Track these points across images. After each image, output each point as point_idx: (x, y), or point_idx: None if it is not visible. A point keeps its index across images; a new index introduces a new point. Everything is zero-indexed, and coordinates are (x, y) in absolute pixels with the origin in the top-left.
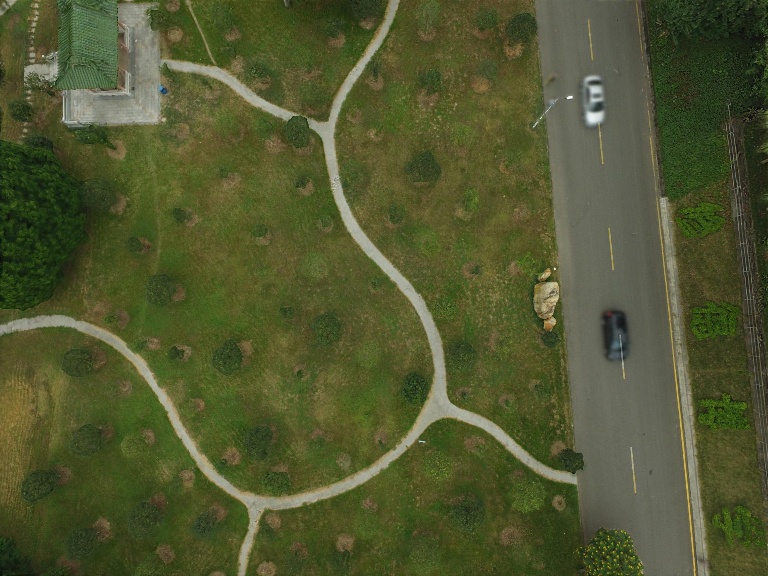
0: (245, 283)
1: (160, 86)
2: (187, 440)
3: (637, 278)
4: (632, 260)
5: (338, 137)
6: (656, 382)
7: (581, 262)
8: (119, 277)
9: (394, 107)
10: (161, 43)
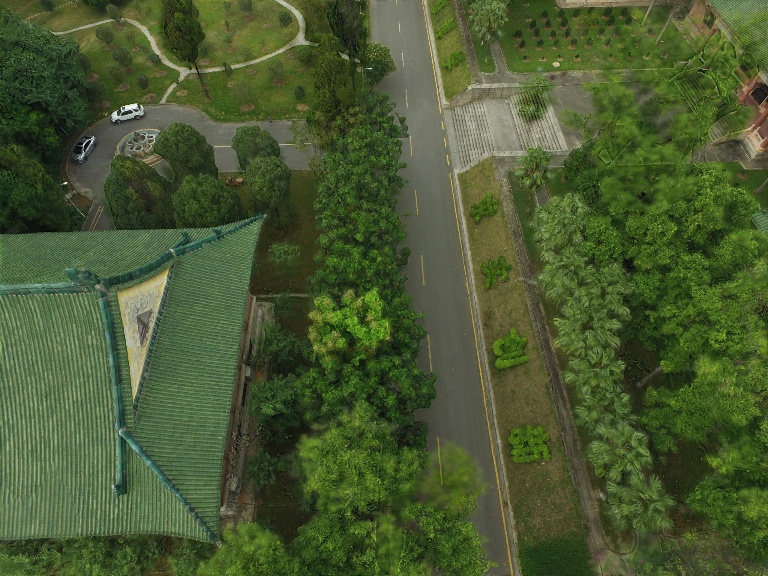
0: (210, 7)
1: None
2: (157, 51)
3: (409, 7)
4: (407, 3)
5: None
6: (417, 34)
7: (381, 3)
8: (147, 5)
9: None
10: None
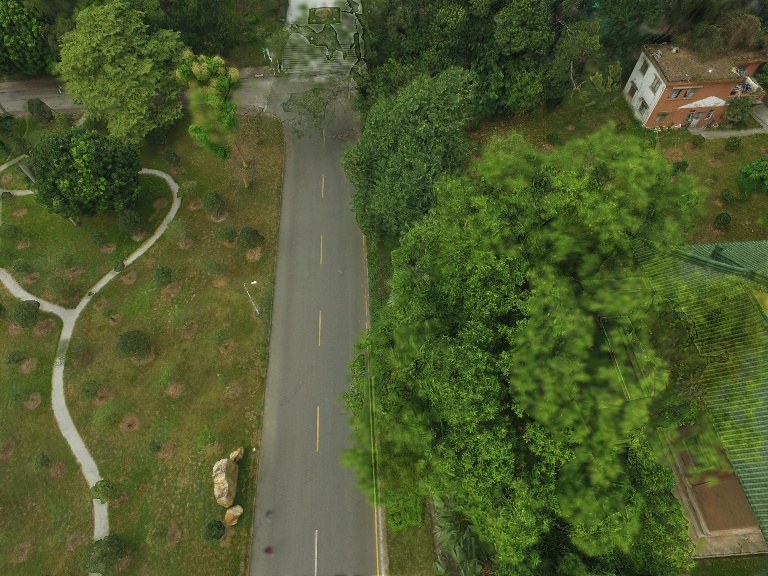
0: None
1: None
2: None
3: (342, 461)
4: (339, 440)
5: (78, 321)
6: None
7: (285, 442)
8: None
9: (139, 298)
10: None
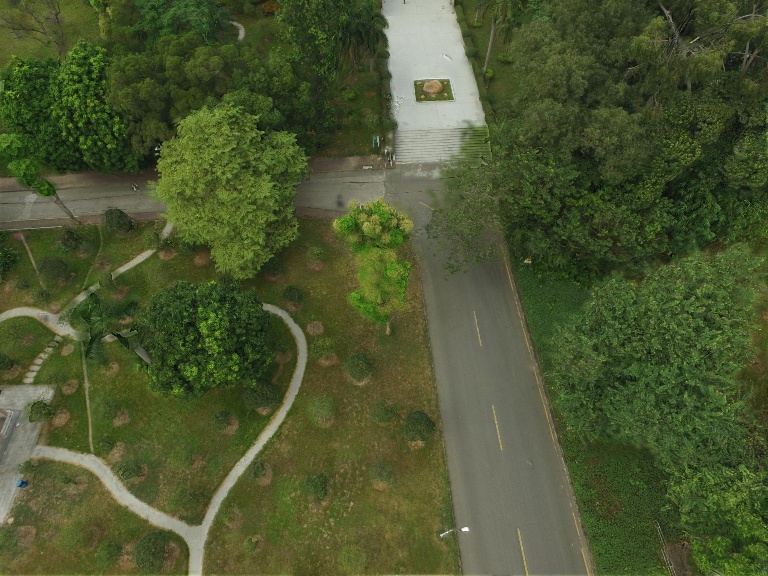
0: None
1: (19, 481)
2: None
3: None
4: None
5: (209, 547)
6: None
7: None
8: None
9: (280, 507)
10: (43, 428)
